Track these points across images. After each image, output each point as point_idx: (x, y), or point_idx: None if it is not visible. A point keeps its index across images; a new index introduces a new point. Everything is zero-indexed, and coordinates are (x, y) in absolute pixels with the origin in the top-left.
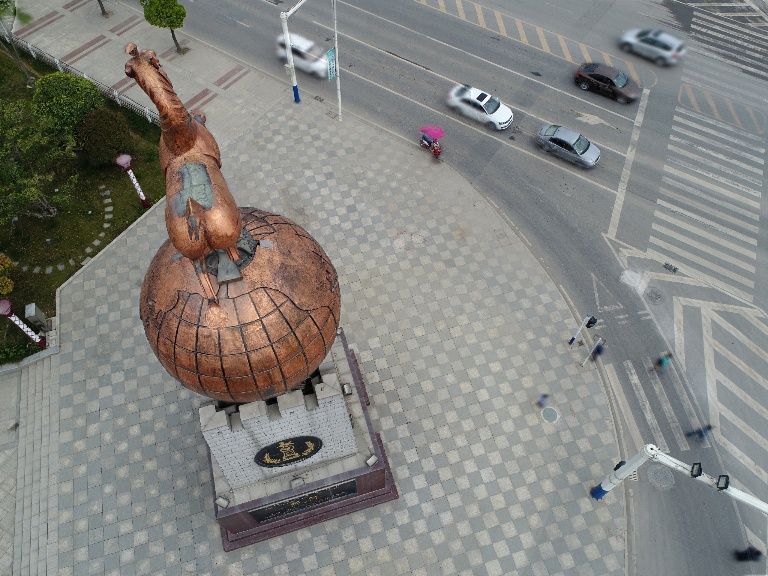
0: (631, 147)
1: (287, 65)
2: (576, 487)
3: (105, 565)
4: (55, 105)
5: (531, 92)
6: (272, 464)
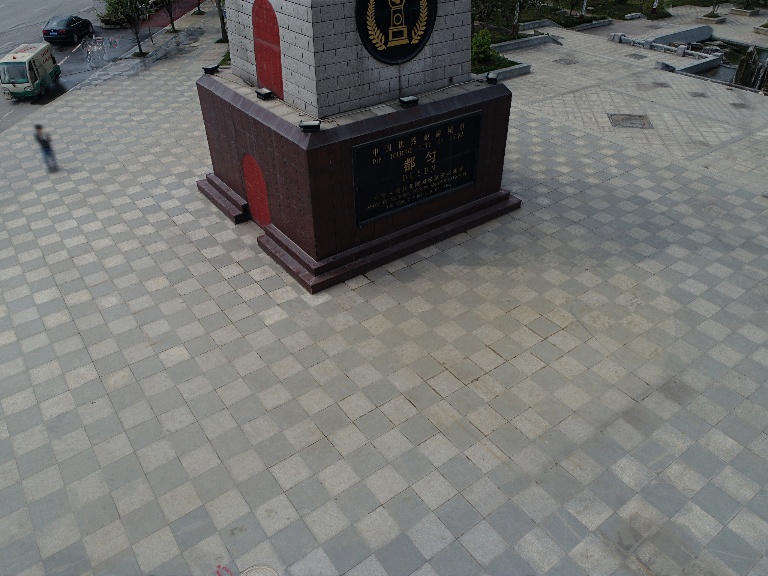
0: None
1: None
2: None
3: None
4: None
5: None
6: None
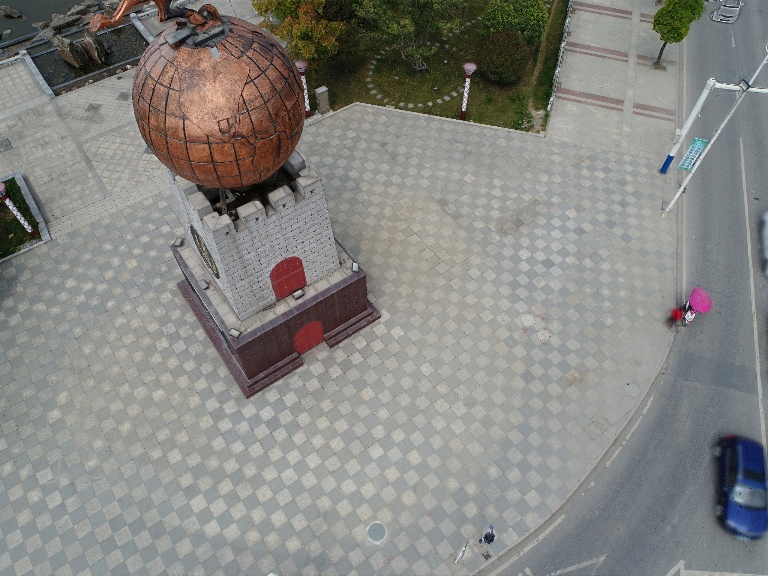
0: None
1: (678, 130)
2: None
3: (157, 219)
4: (502, 8)
5: None
6: None
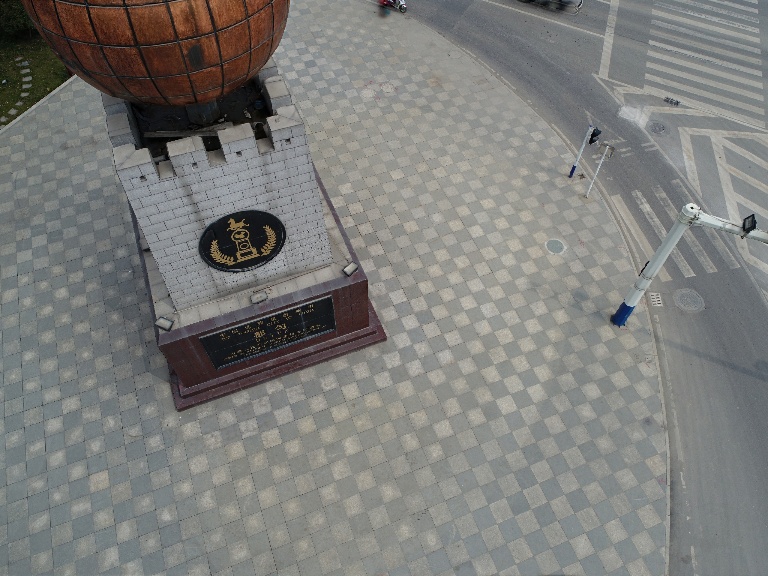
0: None
1: None
2: (593, 316)
3: (26, 437)
4: None
5: None
6: (224, 266)
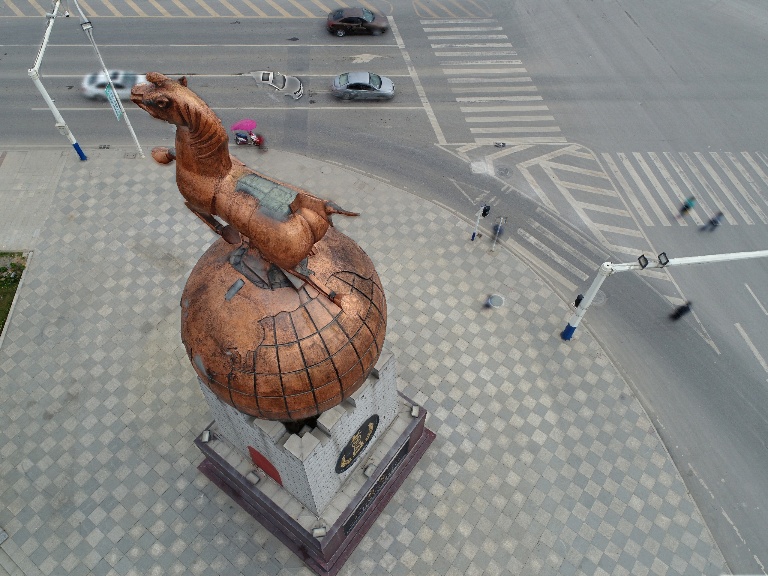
0: (409, 67)
1: (58, 124)
2: (550, 341)
3: None
4: None
5: (300, 56)
6: (346, 466)
